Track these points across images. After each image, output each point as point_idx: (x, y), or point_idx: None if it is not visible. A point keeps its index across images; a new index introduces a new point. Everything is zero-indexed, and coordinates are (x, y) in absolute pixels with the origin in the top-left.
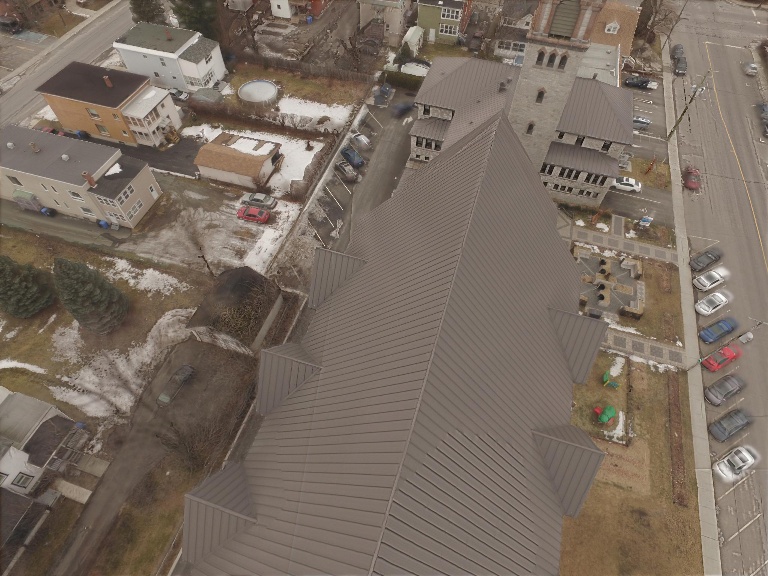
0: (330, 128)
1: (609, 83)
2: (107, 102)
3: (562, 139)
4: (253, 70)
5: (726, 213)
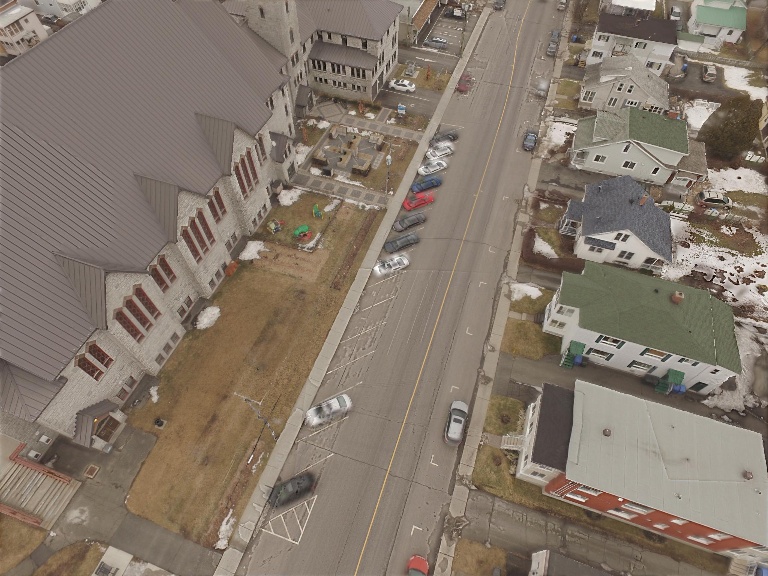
0: None
1: (413, 8)
2: None
3: (331, 40)
4: None
5: (481, 108)
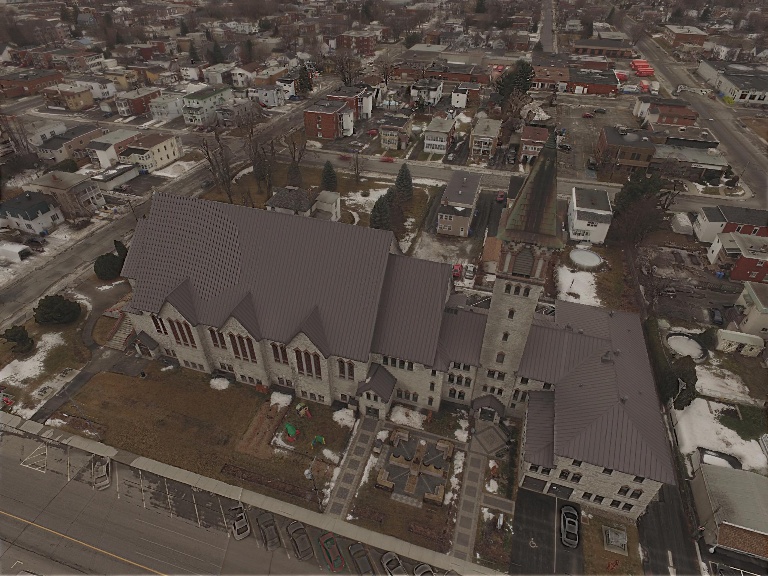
0: (564, 298)
1: (763, 524)
2: (512, 195)
3: None
4: (617, 255)
5: None
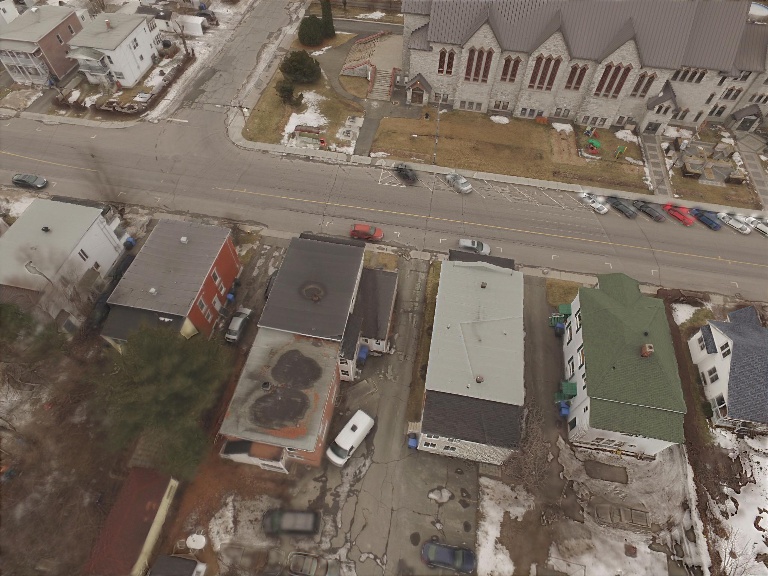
0: None
1: None
2: None
3: None
4: None
5: None
